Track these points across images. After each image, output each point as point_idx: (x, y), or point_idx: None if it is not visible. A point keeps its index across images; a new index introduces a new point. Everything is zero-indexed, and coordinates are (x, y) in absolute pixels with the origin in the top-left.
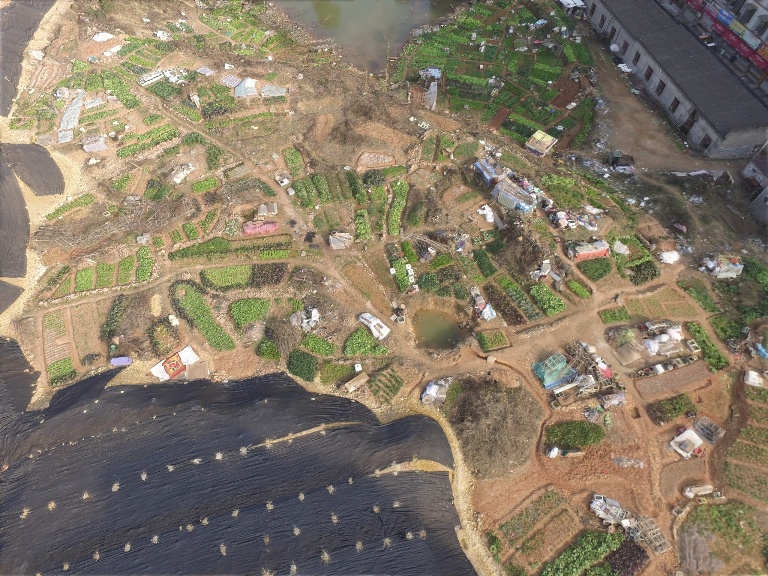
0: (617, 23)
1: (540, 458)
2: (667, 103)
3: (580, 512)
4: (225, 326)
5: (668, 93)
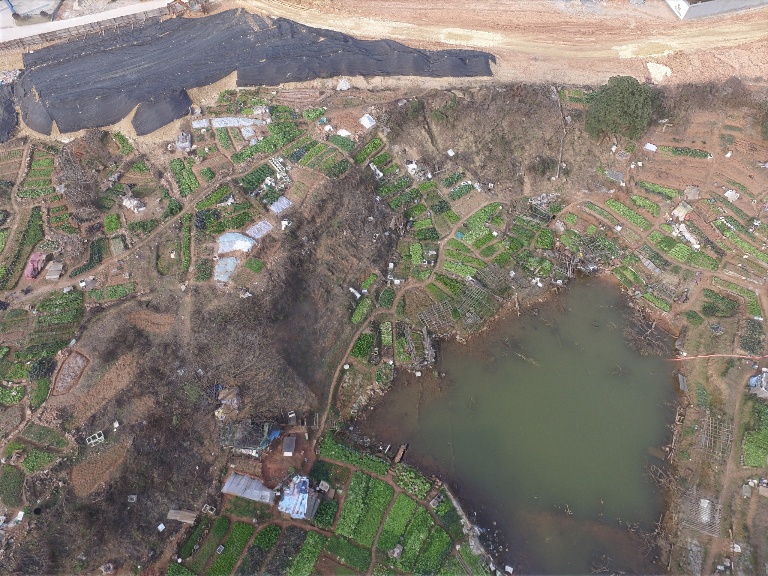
0: None
1: None
2: None
3: None
4: None
5: None
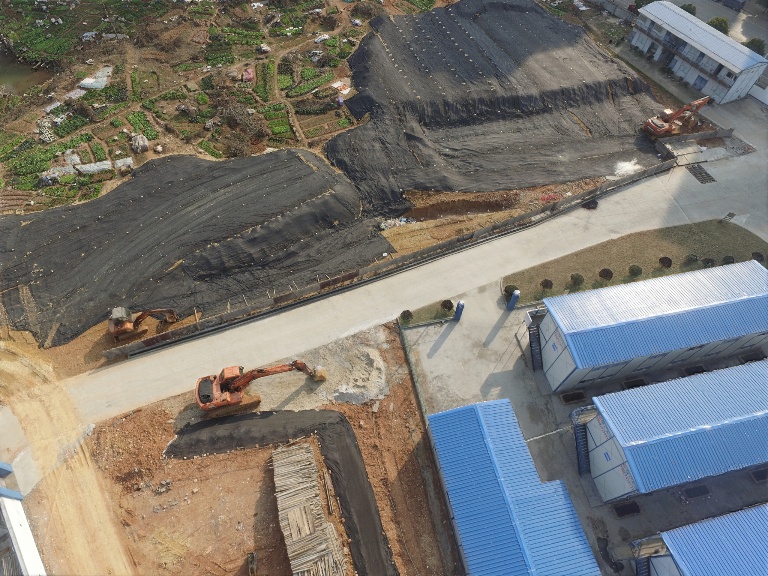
0: None
1: (383, 5)
2: None
3: None
4: None
5: None
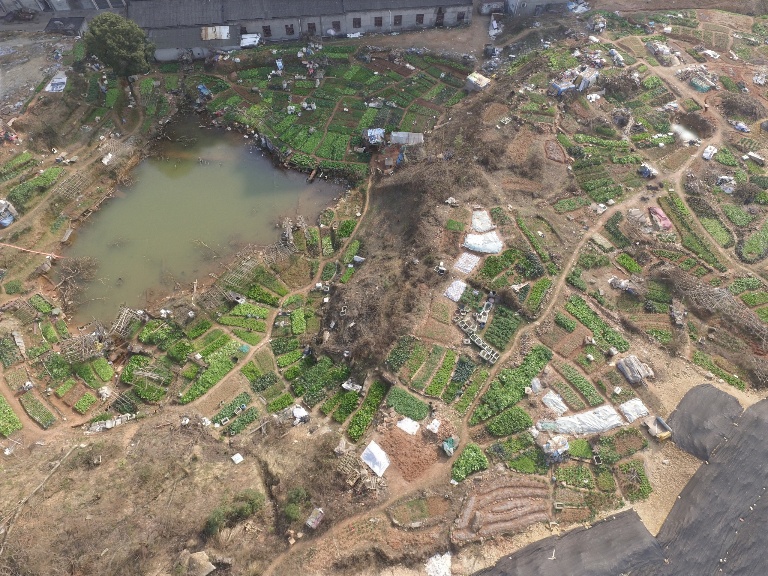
0: (313, 18)
1: None
2: (413, 22)
3: (765, 88)
4: (760, 225)
5: (409, 17)
